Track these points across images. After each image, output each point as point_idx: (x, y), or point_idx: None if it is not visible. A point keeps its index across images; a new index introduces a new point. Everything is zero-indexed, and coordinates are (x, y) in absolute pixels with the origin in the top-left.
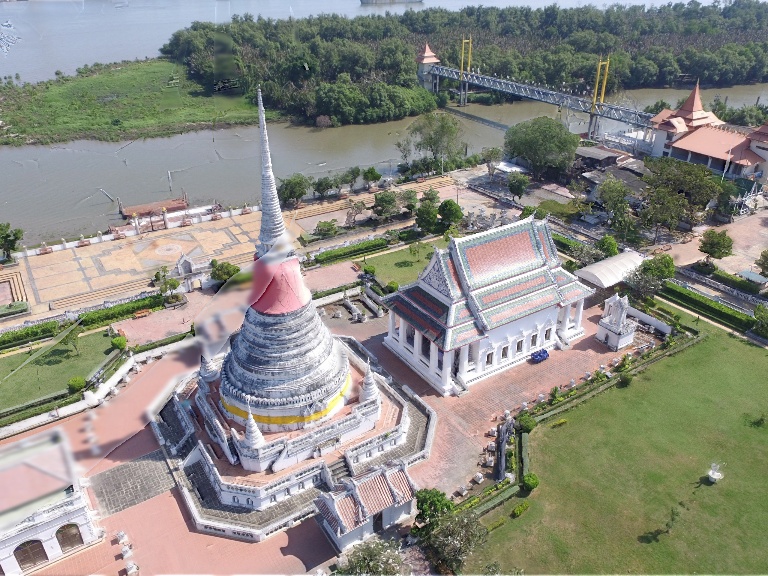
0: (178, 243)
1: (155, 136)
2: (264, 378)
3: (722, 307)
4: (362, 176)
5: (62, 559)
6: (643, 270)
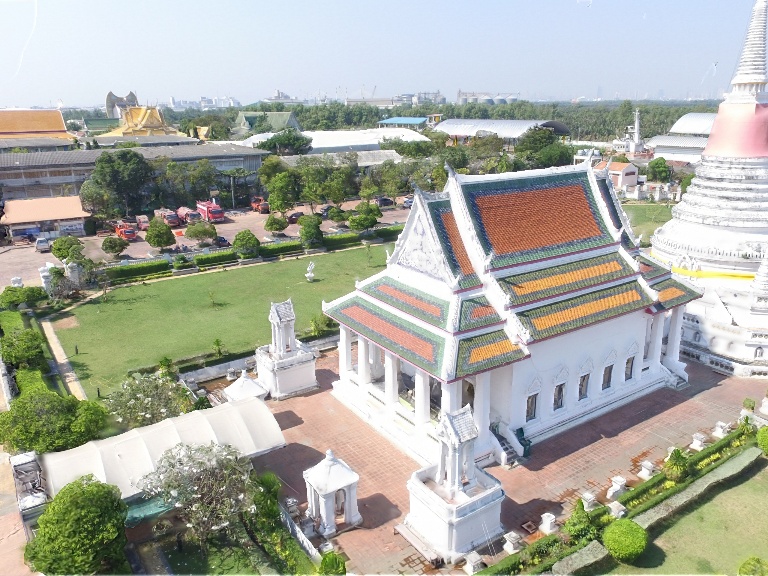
0: None
1: None
2: None
3: None
4: None
5: None
6: None
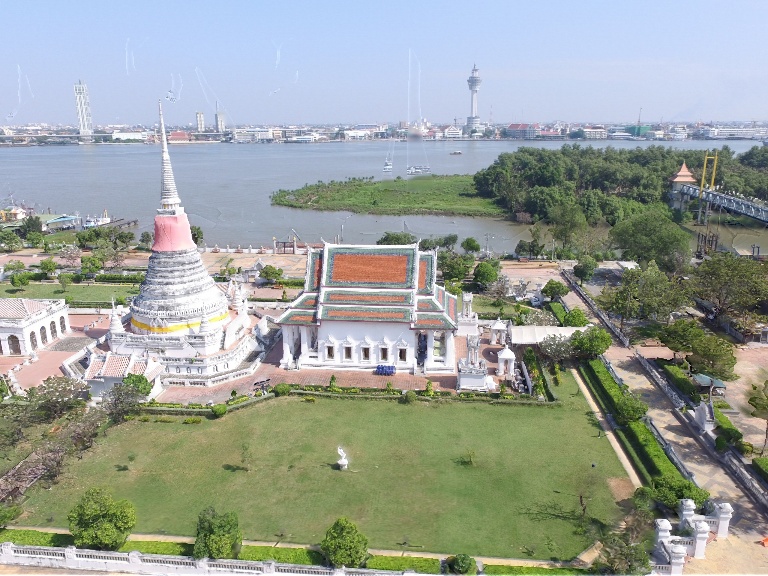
0: (286, 261)
1: (390, 214)
2: None
3: (613, 389)
4: (460, 244)
5: (8, 356)
6: (568, 338)
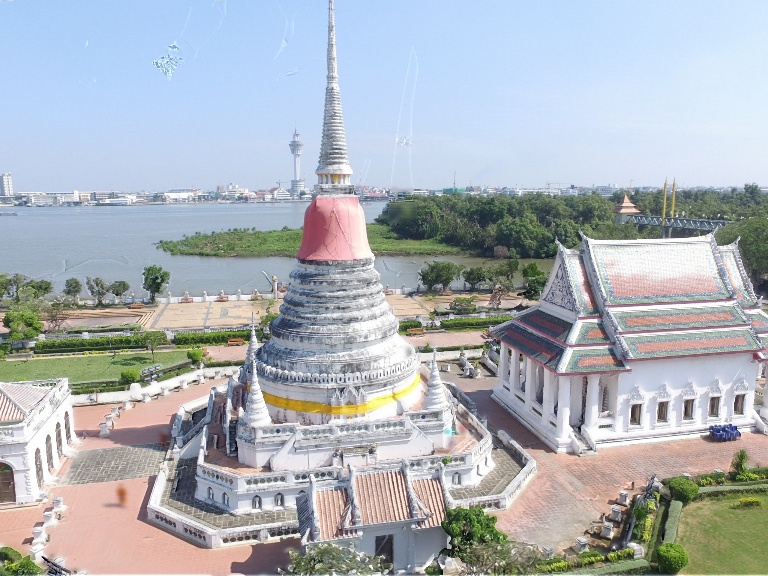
0: None
1: None
2: (292, 347)
3: None
4: (521, 271)
5: None
6: None
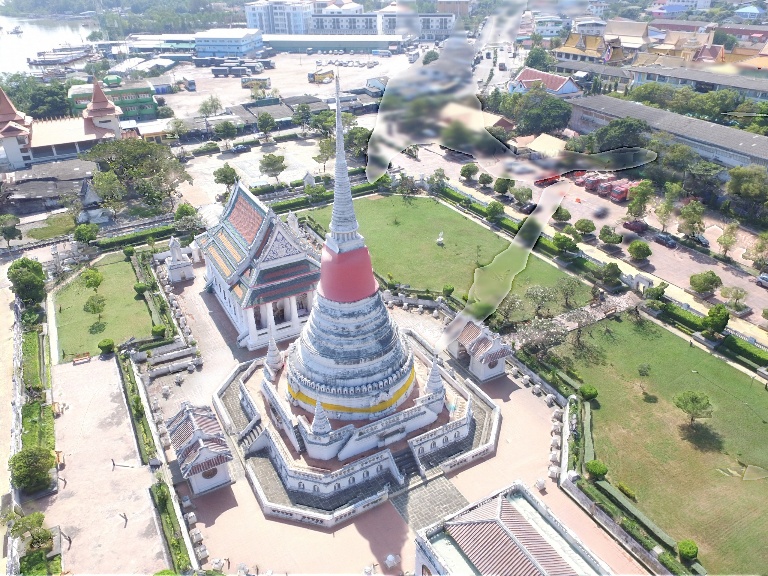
0: None
1: None
2: (395, 347)
3: (287, 202)
4: None
5: None
6: None
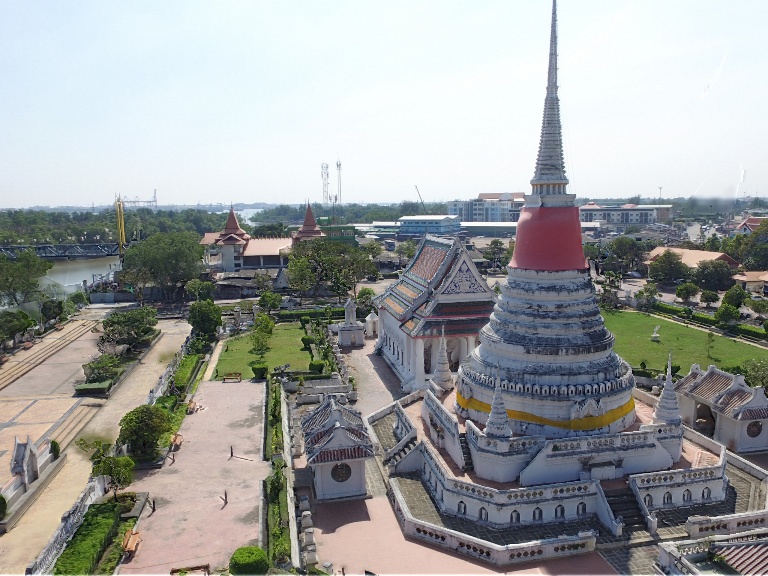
0: None
1: None
2: (608, 354)
3: None
4: None
5: None
6: None
